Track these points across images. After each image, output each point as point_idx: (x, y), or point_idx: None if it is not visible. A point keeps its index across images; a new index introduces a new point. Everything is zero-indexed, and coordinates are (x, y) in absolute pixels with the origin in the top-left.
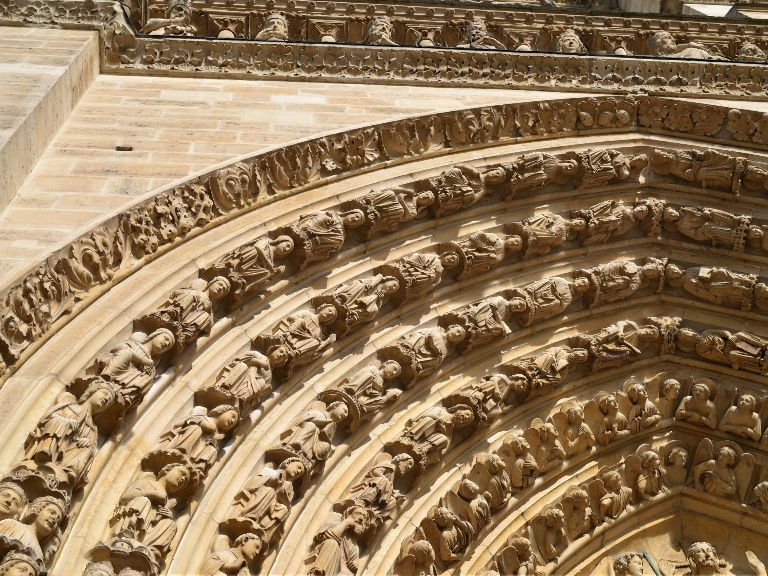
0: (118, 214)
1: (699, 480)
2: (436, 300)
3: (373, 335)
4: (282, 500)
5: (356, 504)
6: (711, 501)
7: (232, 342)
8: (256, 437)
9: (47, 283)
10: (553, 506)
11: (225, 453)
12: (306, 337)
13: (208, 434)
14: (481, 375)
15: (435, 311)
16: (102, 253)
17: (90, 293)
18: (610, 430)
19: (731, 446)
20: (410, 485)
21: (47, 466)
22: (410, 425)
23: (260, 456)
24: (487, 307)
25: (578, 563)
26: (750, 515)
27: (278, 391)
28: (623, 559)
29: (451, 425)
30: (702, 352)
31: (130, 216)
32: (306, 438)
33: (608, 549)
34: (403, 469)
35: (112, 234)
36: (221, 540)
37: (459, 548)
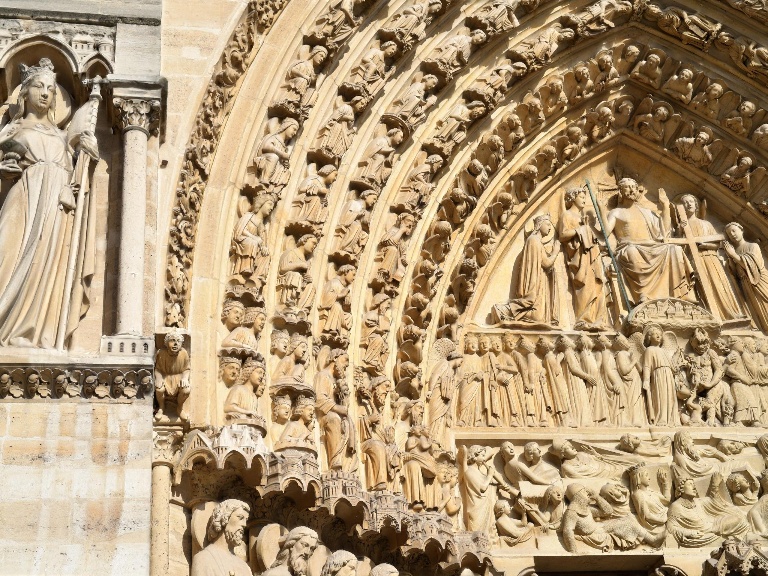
0: (248, 4)
1: (637, 125)
2: (465, 1)
3: (418, 48)
4: (365, 228)
5: (406, 209)
6: (643, 142)
7: (327, 95)
8: (344, 171)
9: (217, 101)
10: (531, 161)
11: (328, 195)
12: (377, 79)
13: (322, 196)
14: (492, 63)
15: (464, 13)
16: (243, 49)
17: (237, 86)
18: (580, 95)
19: (667, 106)
20: (437, 170)
21: (251, 280)
22: (441, 125)
23: (347, 187)
24: (505, 10)
25: (541, 195)
26: (668, 157)
27: (356, 126)
28: (573, 194)
29: (470, 122)
30: (662, 26)
31: (256, 4)
32: (377, 170)
33: (563, 182)
34: (436, 169)
35: (247, 27)
36: (331, 268)
37: (466, 214)
